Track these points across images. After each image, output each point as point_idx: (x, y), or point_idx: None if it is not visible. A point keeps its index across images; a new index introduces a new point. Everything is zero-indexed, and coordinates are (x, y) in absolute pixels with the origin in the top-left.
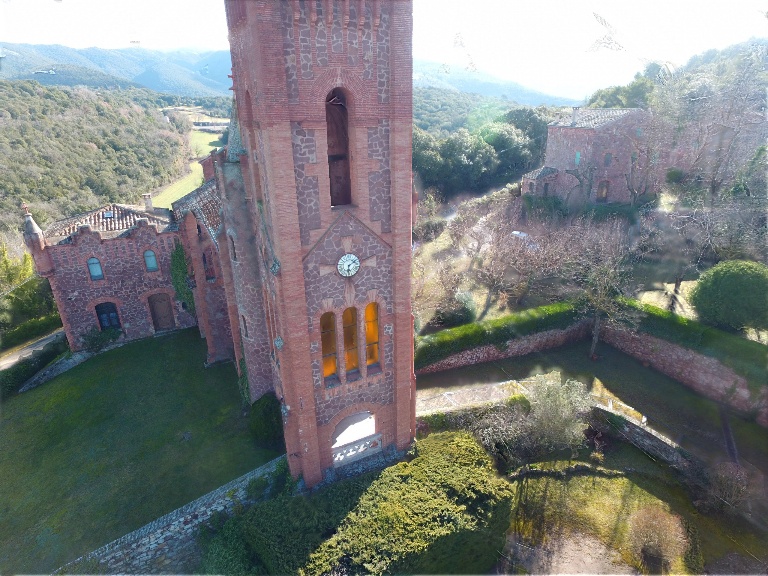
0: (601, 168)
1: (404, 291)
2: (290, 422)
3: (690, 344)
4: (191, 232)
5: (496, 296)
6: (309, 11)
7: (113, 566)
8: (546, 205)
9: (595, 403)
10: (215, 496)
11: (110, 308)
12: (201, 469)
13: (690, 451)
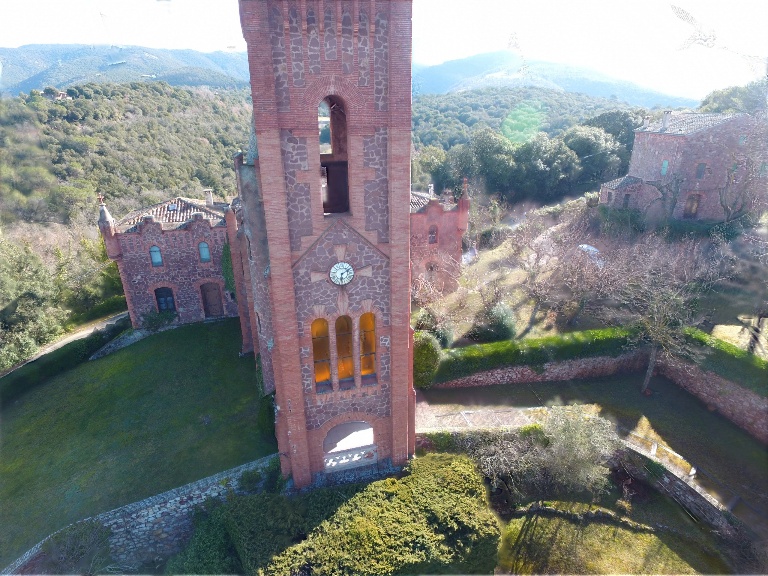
0: (691, 180)
1: (401, 304)
2: (280, 422)
3: (766, 392)
4: (231, 228)
5: (545, 313)
6: (301, 19)
7: (115, 531)
8: (621, 218)
9: (622, 446)
10: (209, 482)
11: (167, 293)
12: (210, 453)
13: (744, 517)
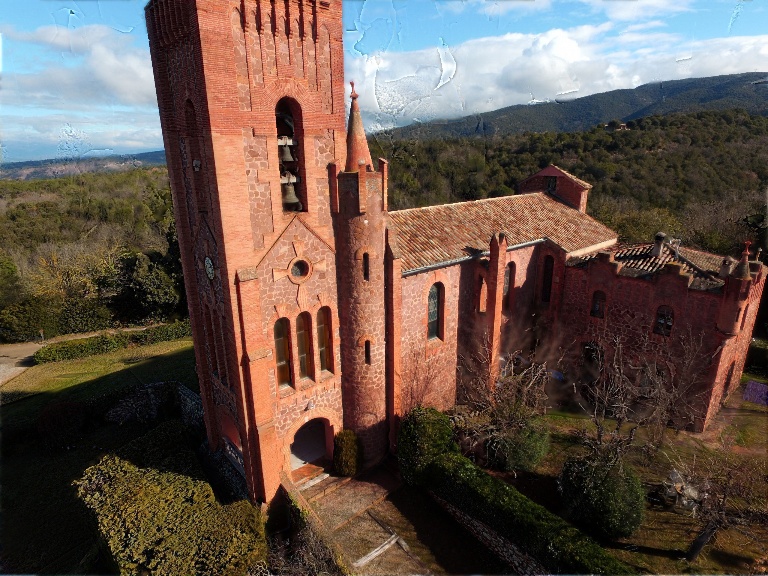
0: None
1: (230, 319)
2: None
3: None
4: None
5: None
6: None
7: None
8: None
9: None
10: None
11: None
12: None
13: None
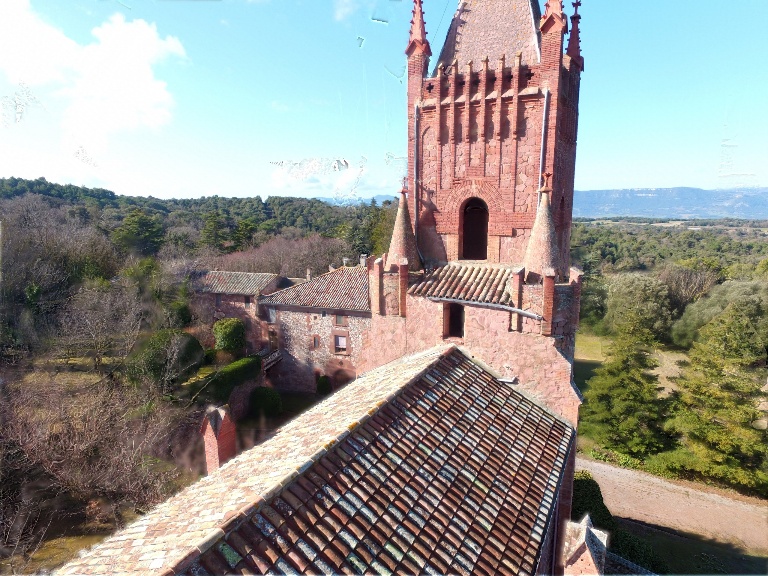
0: None
1: None
2: None
3: (190, 407)
4: None
5: (48, 539)
6: None
7: None
8: None
9: None
10: (634, 564)
11: None
12: None
13: None
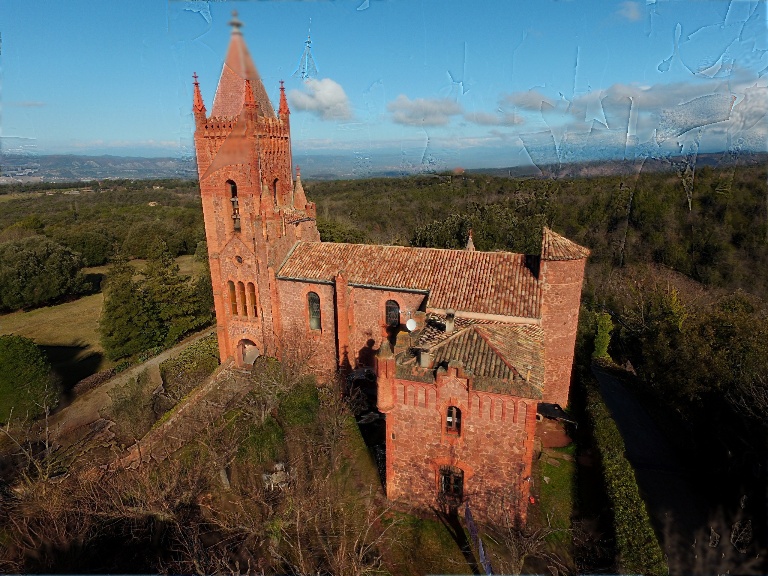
0: None
1: None
2: None
3: None
4: None
5: None
6: None
7: None
8: None
9: None
10: None
11: None
12: None
13: None
